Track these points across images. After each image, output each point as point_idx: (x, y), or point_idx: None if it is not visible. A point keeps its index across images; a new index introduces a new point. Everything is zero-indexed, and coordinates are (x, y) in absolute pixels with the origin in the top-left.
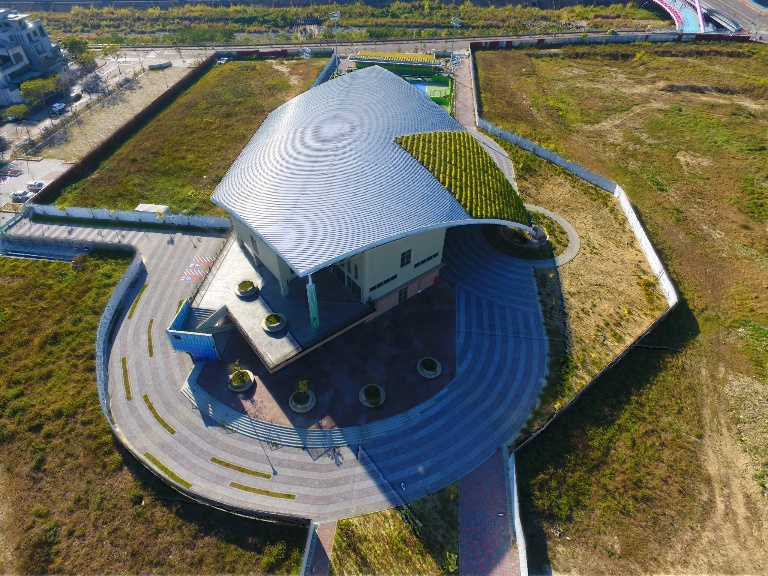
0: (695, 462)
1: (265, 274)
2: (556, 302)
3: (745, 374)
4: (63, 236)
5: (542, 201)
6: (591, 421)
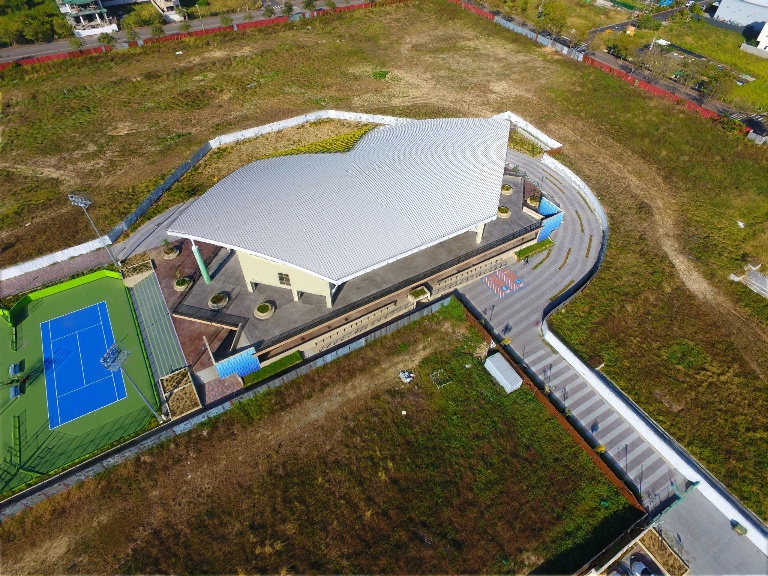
0: None
1: None
2: None
3: None
4: (605, 423)
5: None
6: None
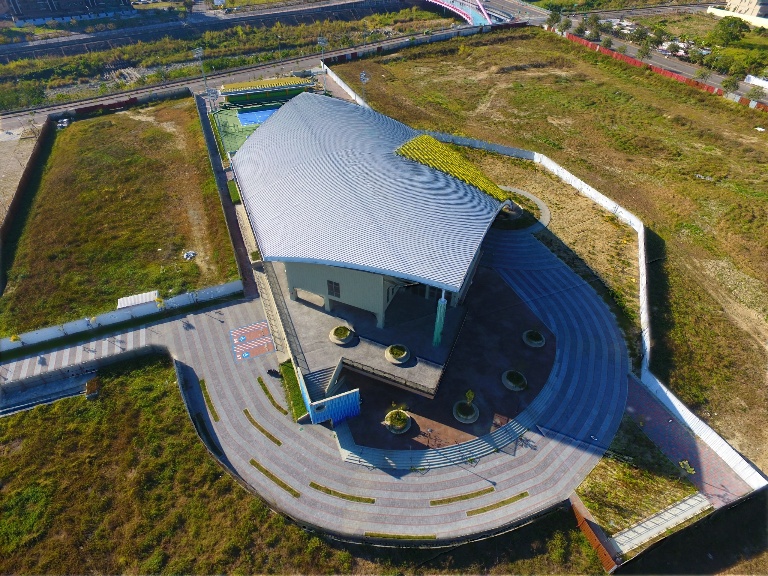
0: (733, 327)
1: (345, 316)
2: (569, 253)
3: (709, 258)
4: (38, 370)
5: (492, 180)
6: (664, 328)
